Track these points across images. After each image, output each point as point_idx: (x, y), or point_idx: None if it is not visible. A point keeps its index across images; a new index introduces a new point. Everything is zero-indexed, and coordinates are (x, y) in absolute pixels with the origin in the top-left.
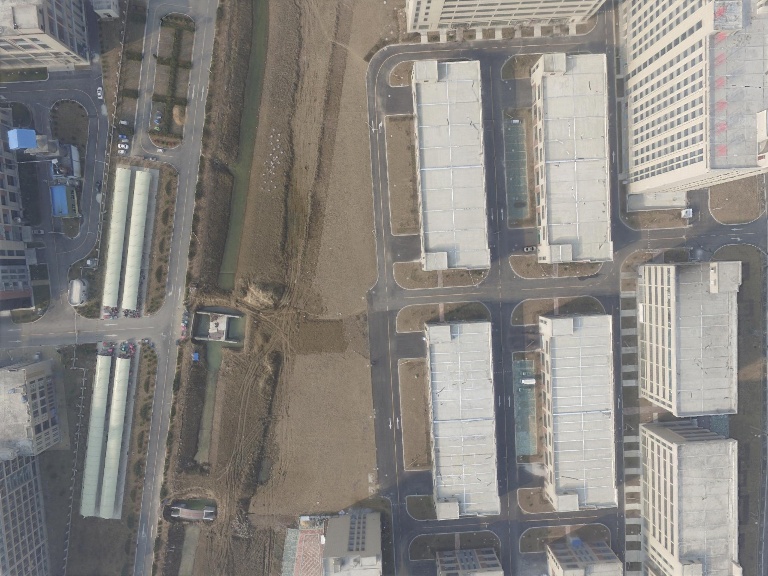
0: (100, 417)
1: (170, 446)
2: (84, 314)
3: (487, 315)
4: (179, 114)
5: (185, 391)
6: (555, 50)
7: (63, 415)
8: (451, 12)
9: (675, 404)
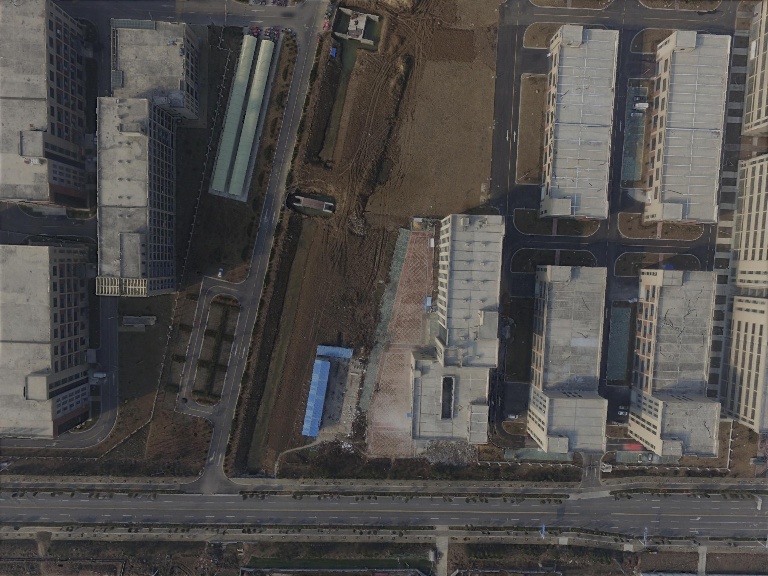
0: (240, 95)
1: (300, 135)
2: None
3: None
4: None
5: (320, 83)
6: None
7: (204, 94)
8: None
9: None
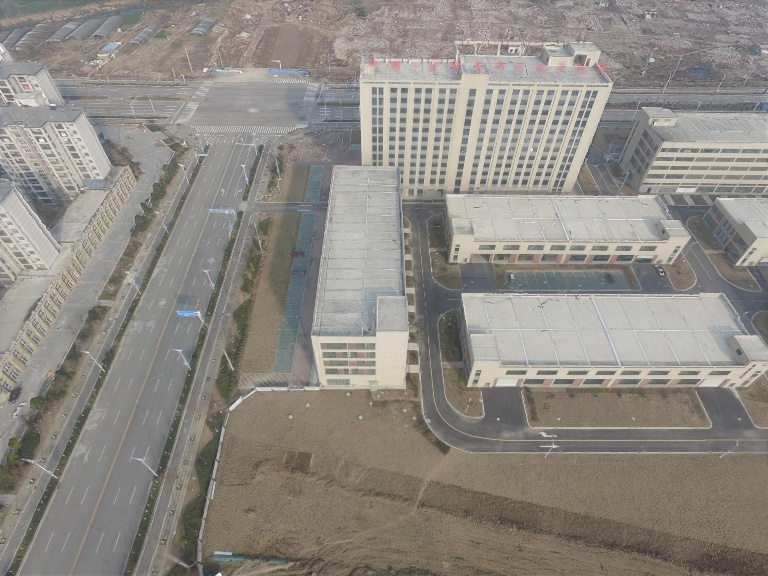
0: None
1: None
2: None
3: (765, 315)
4: None
5: None
6: (426, 244)
7: None
8: None
9: None
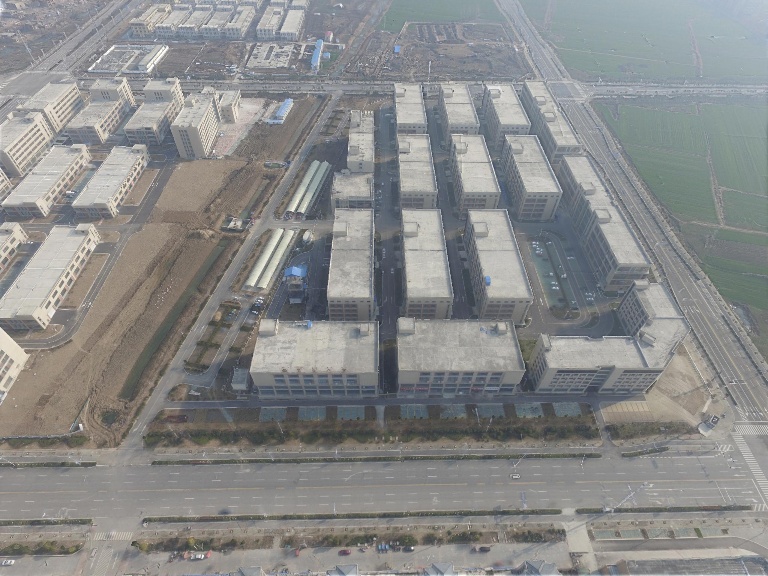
0: (309, 192)
1: None
2: None
3: (76, 219)
4: None
5: None
6: None
7: None
8: None
9: None
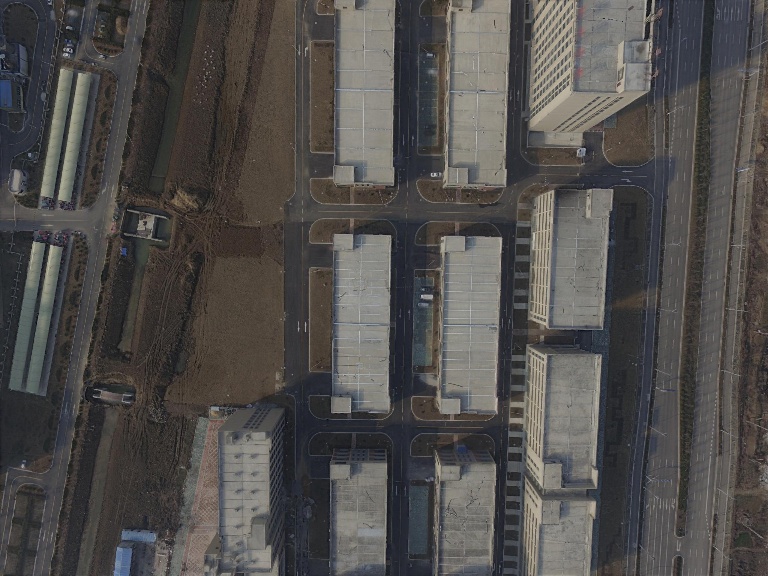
0: (32, 299)
1: (95, 332)
2: (23, 203)
3: (393, 233)
4: (121, 24)
5: (112, 282)
6: None
7: None
8: None
9: (547, 317)
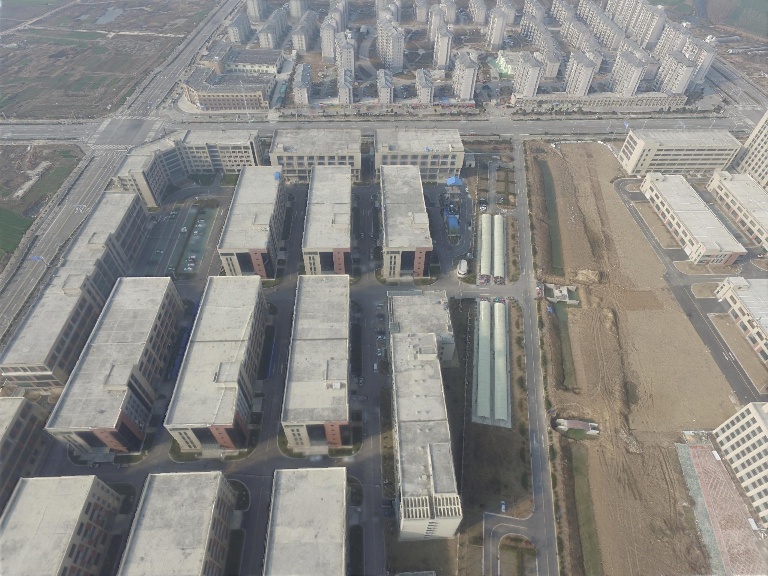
0: (487, 340)
1: (545, 367)
2: (466, 281)
3: None
4: None
5: (548, 330)
6: None
7: None
8: (656, 160)
9: None
